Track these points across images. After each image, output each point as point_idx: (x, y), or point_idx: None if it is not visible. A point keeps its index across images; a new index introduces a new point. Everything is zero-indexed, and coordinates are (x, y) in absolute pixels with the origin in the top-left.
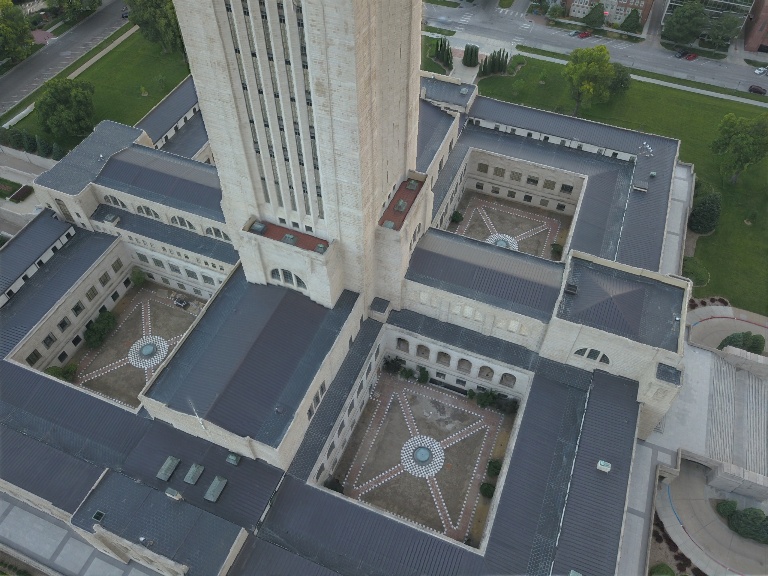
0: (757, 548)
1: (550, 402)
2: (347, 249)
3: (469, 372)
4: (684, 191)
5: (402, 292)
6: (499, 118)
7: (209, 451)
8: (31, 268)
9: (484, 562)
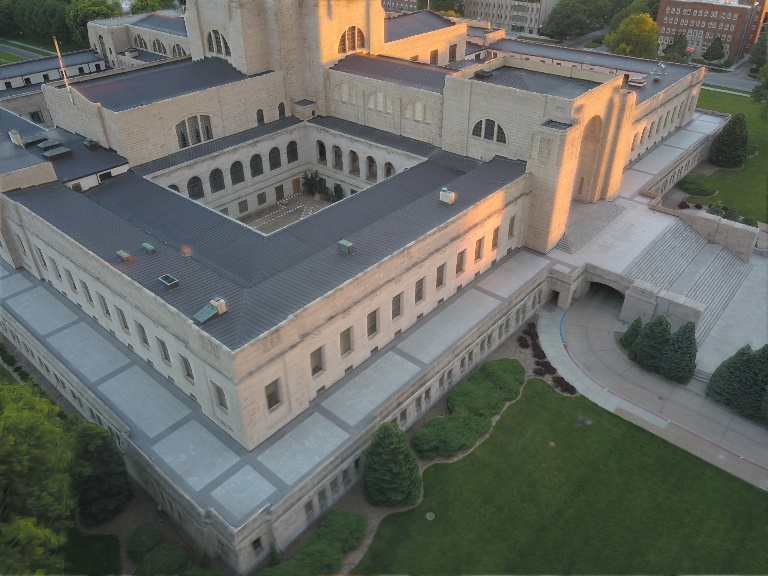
0: (661, 384)
1: (432, 177)
2: (267, 5)
3: (376, 181)
4: (710, 128)
5: (326, 88)
6: (516, 50)
7: (76, 140)
8: (54, 72)
9: (263, 240)
